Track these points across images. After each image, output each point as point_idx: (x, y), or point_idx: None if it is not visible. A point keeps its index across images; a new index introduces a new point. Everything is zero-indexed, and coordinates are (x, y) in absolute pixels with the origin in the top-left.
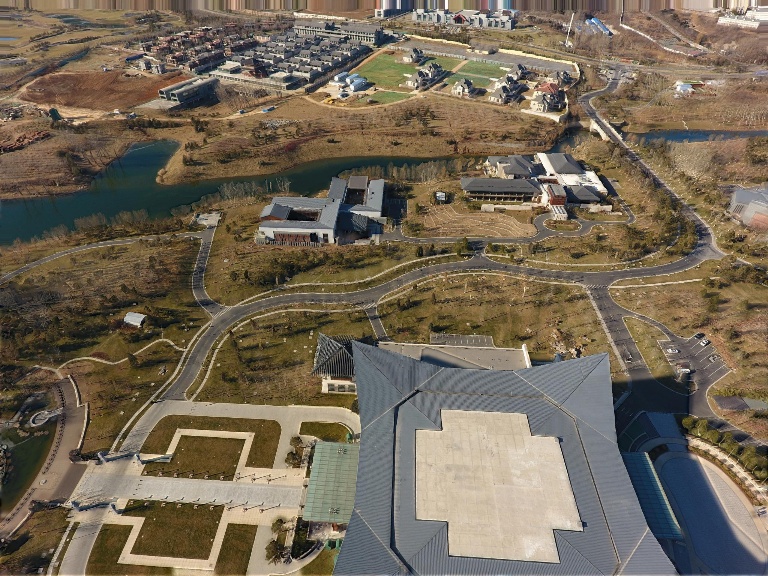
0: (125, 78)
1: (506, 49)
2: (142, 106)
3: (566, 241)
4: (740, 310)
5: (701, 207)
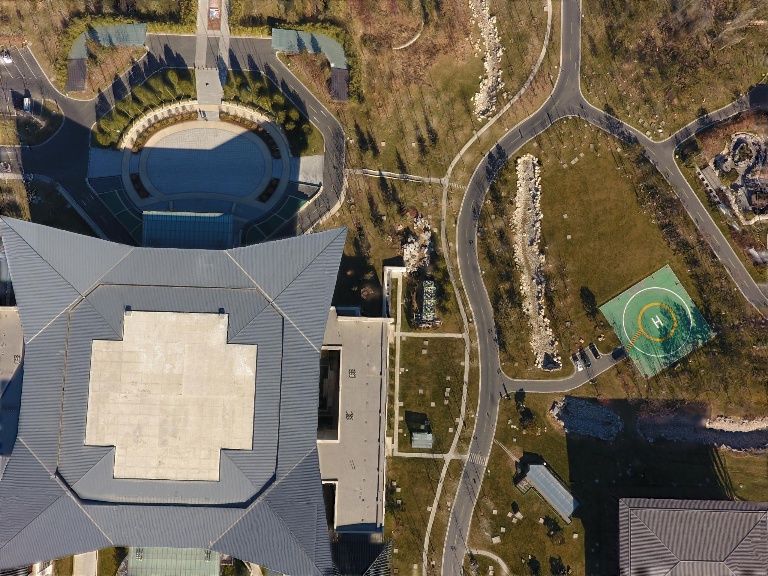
0: None
1: None
2: None
3: None
4: None
5: None
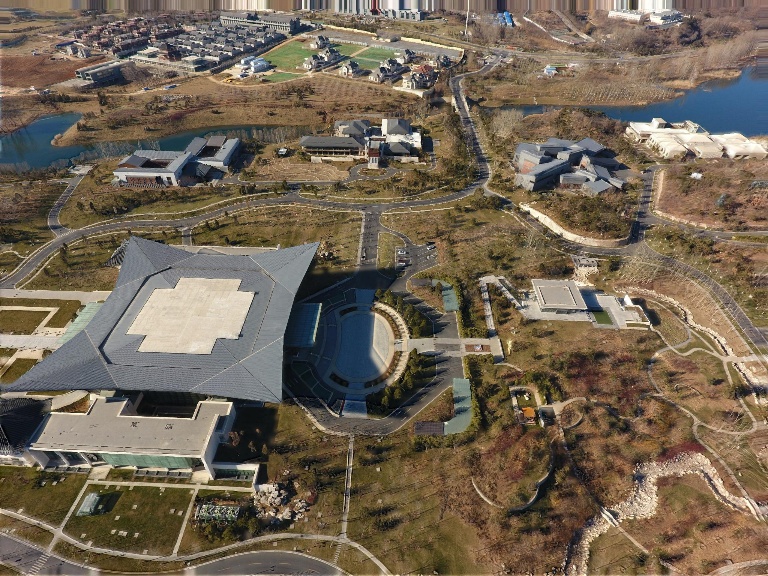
0: (50, 61)
1: (407, 37)
2: (58, 84)
3: (368, 183)
4: (471, 226)
5: (495, 159)
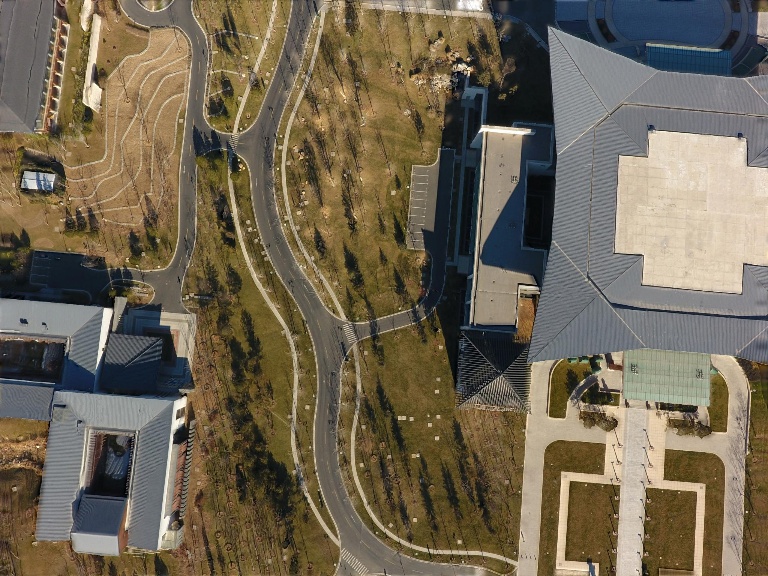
0: None
1: None
2: None
3: None
4: None
5: None
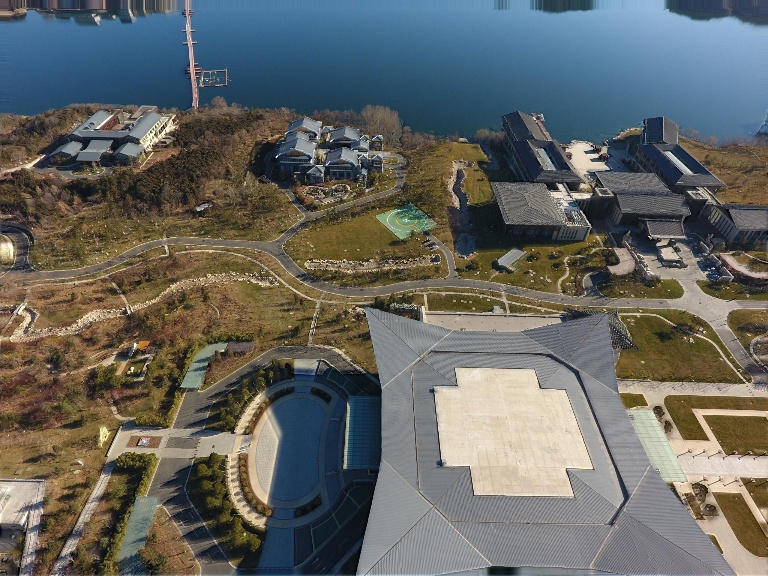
0: None
1: None
2: None
3: None
4: None
5: None
